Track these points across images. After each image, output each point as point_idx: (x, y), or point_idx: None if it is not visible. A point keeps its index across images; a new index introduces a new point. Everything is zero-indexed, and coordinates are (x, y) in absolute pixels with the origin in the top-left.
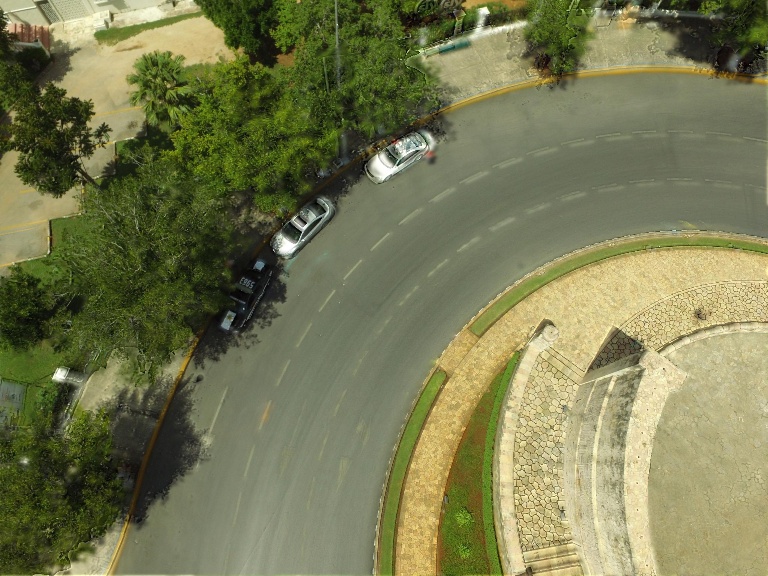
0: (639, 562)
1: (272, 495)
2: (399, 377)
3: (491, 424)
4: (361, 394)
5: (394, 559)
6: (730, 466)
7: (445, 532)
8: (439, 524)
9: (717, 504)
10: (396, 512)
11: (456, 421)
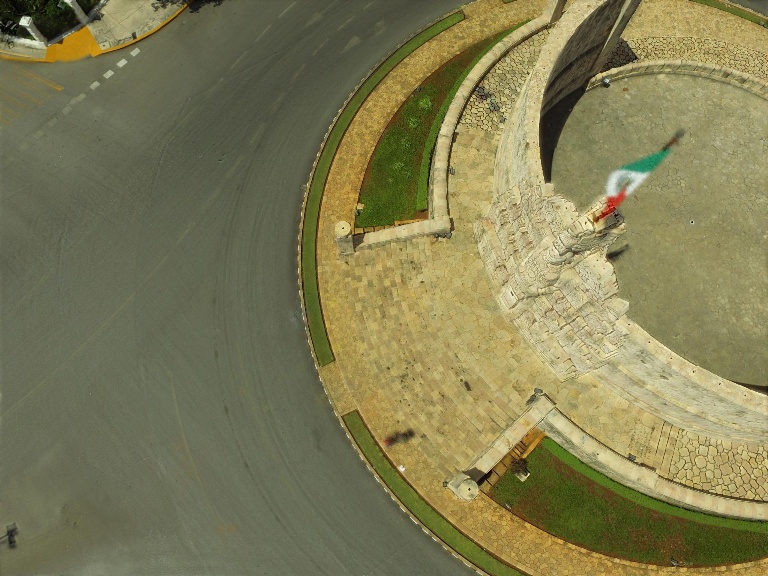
0: (539, 65)
1: (292, 36)
2: (427, 5)
3: (481, 54)
4: (391, 4)
5: (359, 109)
6: (663, 165)
7: (406, 108)
8: (405, 101)
9: (635, 183)
10: (377, 83)
11: (455, 46)
